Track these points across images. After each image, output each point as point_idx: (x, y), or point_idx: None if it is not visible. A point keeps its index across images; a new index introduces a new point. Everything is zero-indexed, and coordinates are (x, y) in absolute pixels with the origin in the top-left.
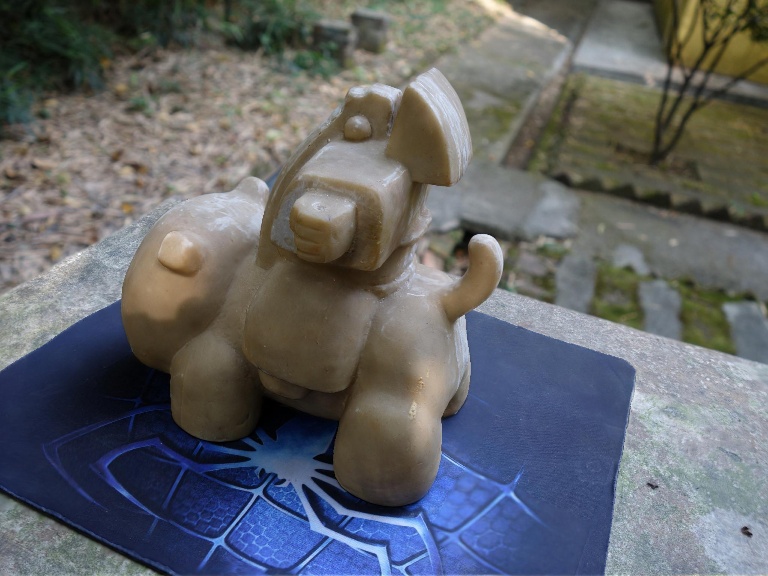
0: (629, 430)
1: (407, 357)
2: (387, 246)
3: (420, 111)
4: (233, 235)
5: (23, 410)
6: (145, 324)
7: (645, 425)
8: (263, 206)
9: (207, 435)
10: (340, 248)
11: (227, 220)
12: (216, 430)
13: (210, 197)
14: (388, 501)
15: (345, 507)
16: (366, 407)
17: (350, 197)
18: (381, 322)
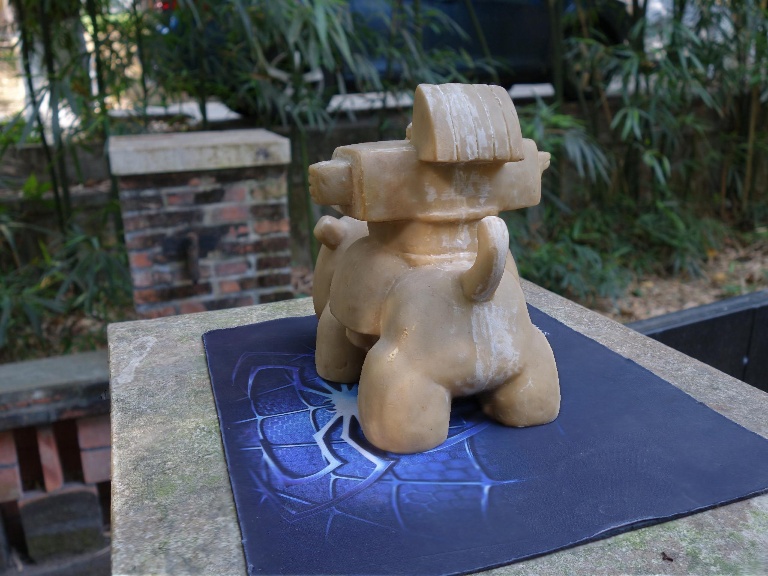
0: (715, 513)
1: (401, 308)
2: (379, 203)
3: (421, 102)
4: None
5: (259, 337)
6: (314, 285)
7: (749, 519)
8: None
9: (320, 372)
10: (332, 194)
11: None
12: (324, 368)
13: None
14: (373, 439)
15: (349, 436)
16: (371, 348)
17: (349, 160)
18: (399, 281)
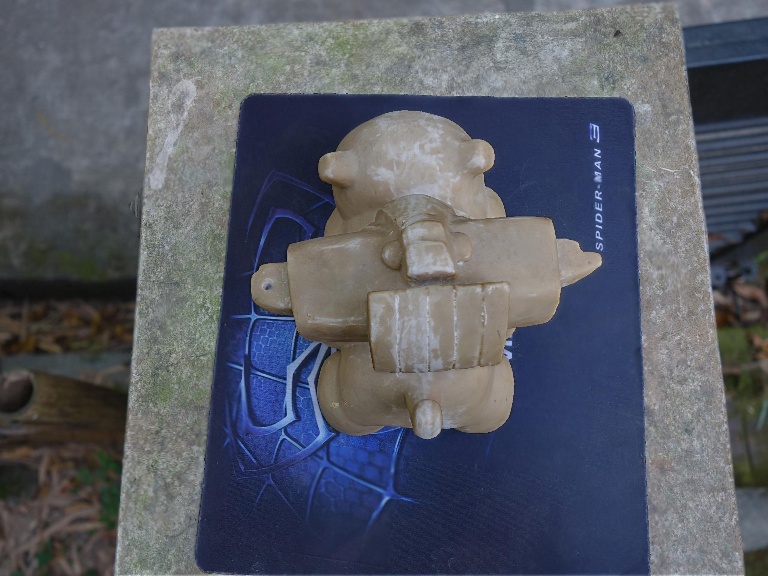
0: None
1: (345, 385)
2: None
3: None
4: (380, 190)
5: (295, 135)
6: None
7: None
8: (464, 176)
9: None
10: None
11: (388, 175)
12: None
13: (415, 140)
14: None
15: (315, 380)
16: (328, 369)
17: None
18: (355, 353)
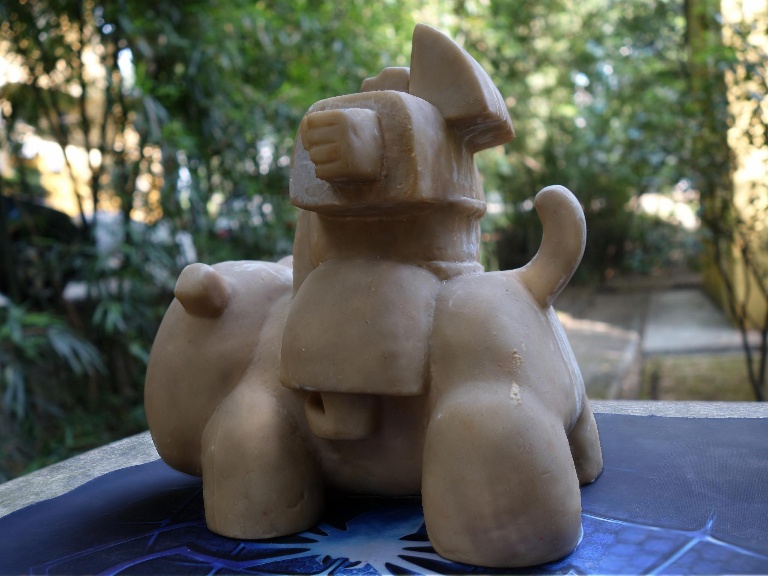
0: None
1: (489, 326)
2: (427, 170)
3: (434, 42)
4: (264, 275)
5: (17, 543)
6: (167, 395)
7: None
8: None
9: (250, 529)
10: (365, 154)
11: (257, 265)
12: (261, 517)
13: None
14: (515, 554)
15: None
16: (450, 406)
17: (369, 108)
18: (447, 298)
